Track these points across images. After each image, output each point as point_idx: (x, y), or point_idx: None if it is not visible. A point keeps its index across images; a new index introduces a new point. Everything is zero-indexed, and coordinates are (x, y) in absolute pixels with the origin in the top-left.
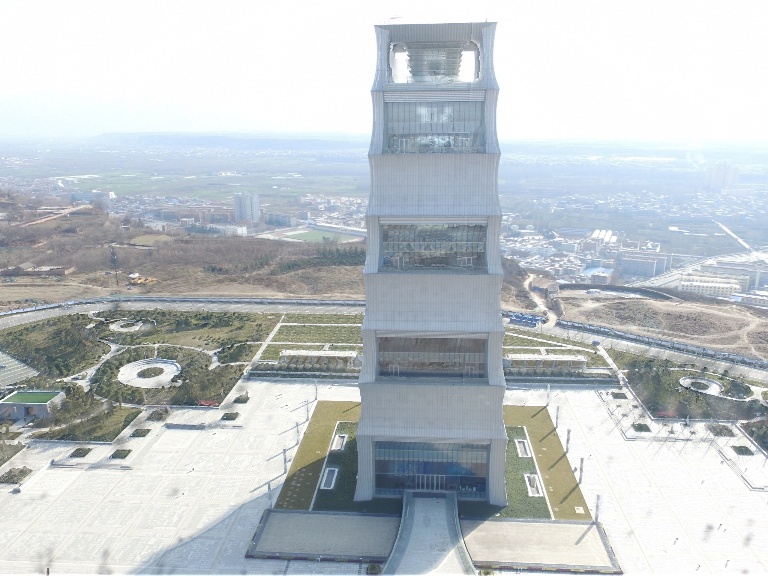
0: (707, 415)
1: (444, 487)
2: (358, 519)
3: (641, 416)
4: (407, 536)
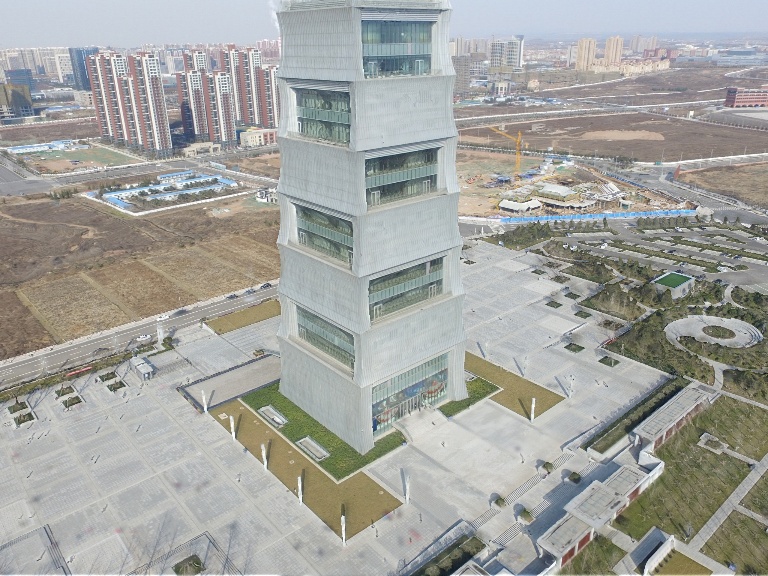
0: None
1: None
2: None
3: None
4: None
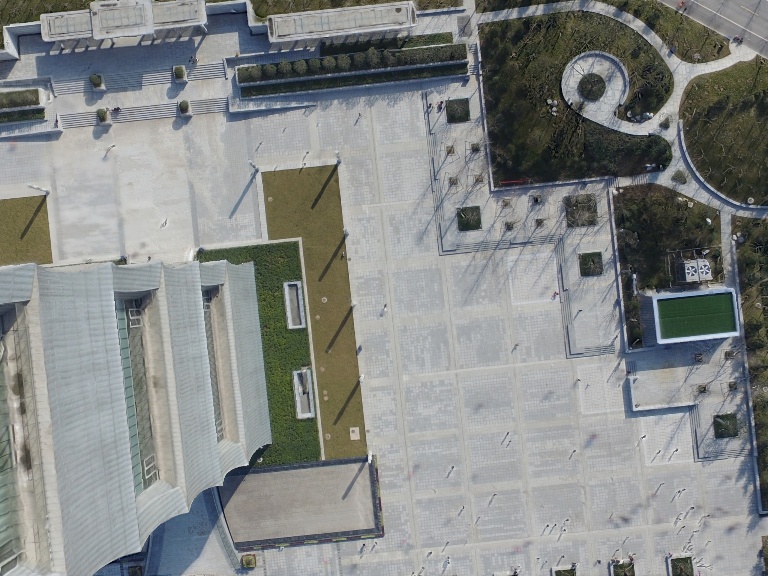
0: (575, 171)
1: None
2: None
3: (477, 181)
4: None
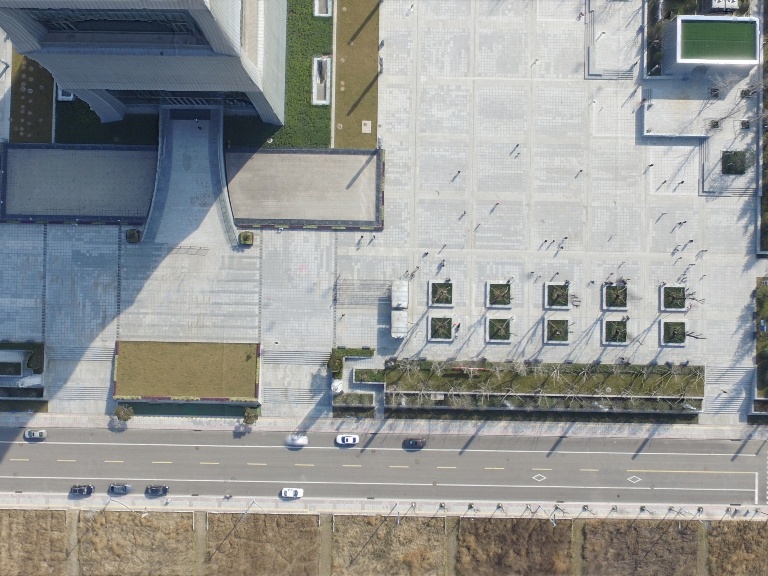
0: None
1: (206, 103)
2: (110, 157)
3: None
4: (165, 186)
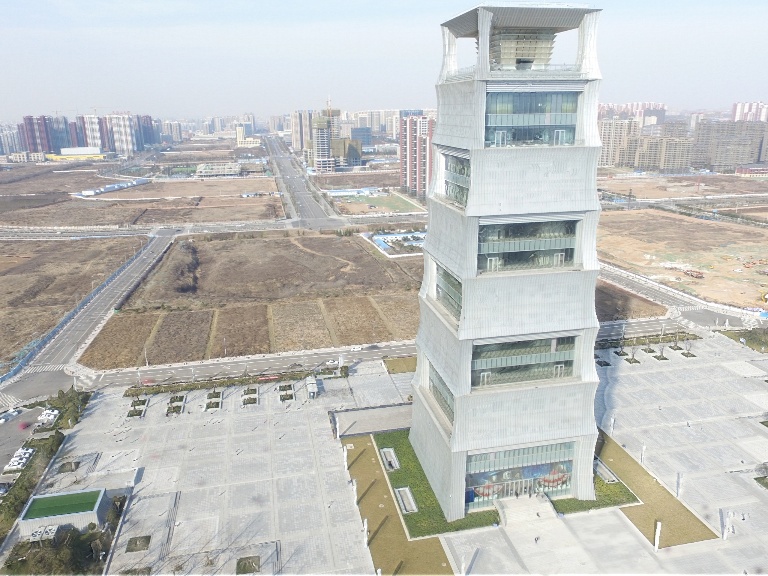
0: None
1: None
2: None
3: None
4: None
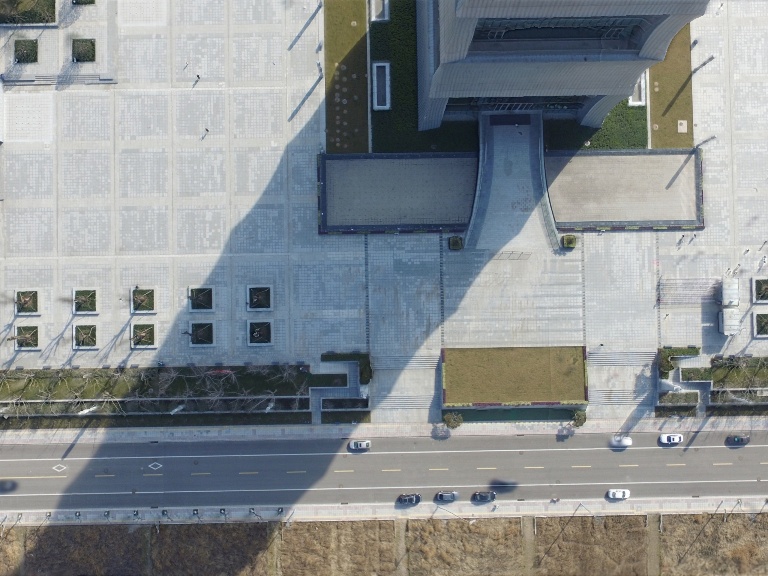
0: None
1: (529, 108)
2: (429, 165)
3: None
4: (487, 192)
